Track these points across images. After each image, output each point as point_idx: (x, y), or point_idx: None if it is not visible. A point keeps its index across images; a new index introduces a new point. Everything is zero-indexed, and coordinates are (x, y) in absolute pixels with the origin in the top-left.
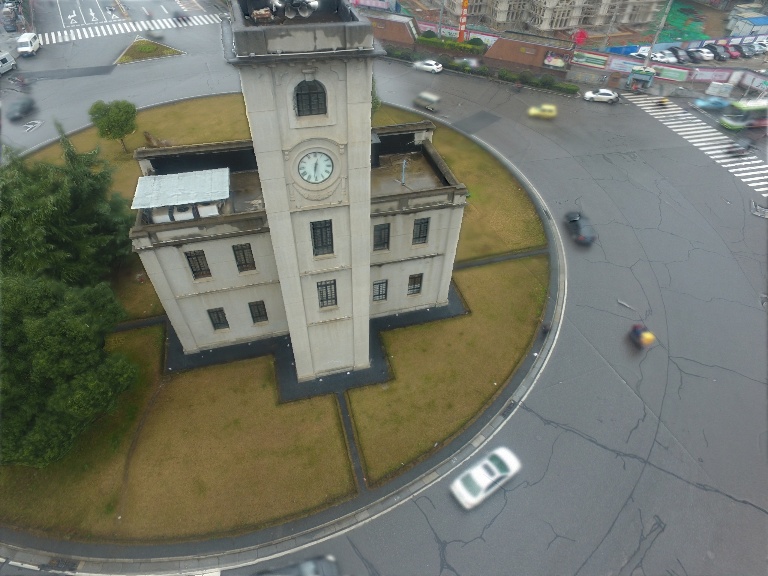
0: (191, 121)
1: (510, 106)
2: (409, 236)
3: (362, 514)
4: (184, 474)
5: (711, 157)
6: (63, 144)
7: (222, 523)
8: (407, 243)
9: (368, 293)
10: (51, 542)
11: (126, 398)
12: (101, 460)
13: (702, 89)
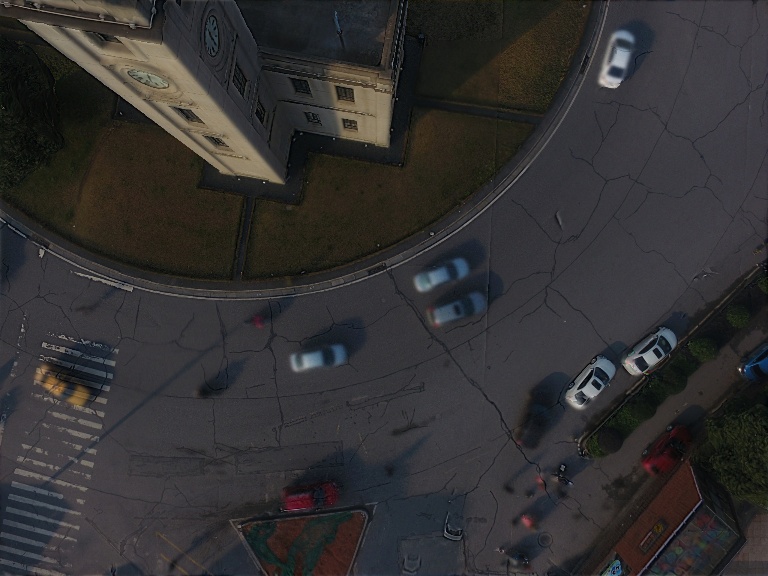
0: None
1: None
2: (332, 94)
3: (231, 294)
4: (118, 215)
5: None
6: None
7: (138, 260)
8: (331, 98)
9: (257, 154)
10: (31, 224)
11: (82, 130)
12: (63, 178)
13: None
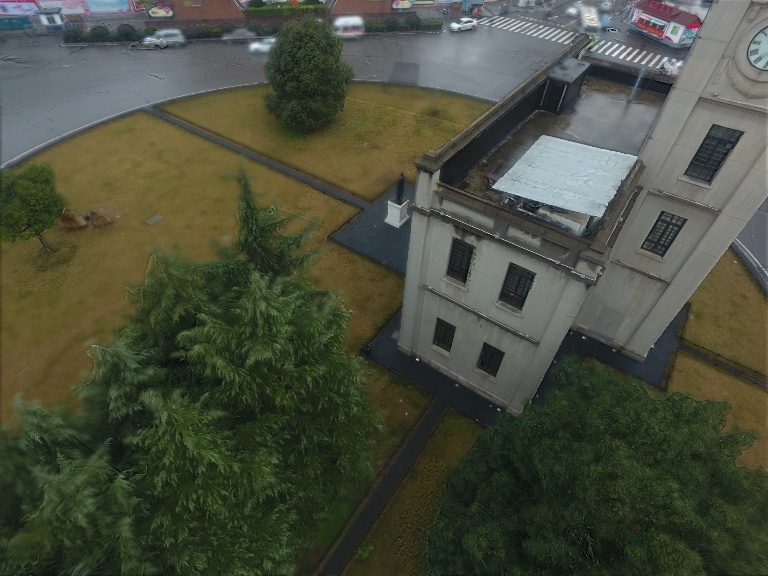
0: (89, 176)
1: (410, 52)
2: None
3: None
4: None
5: None
6: (248, 210)
7: None
8: None
9: None
10: None
11: None
12: None
13: (514, 4)
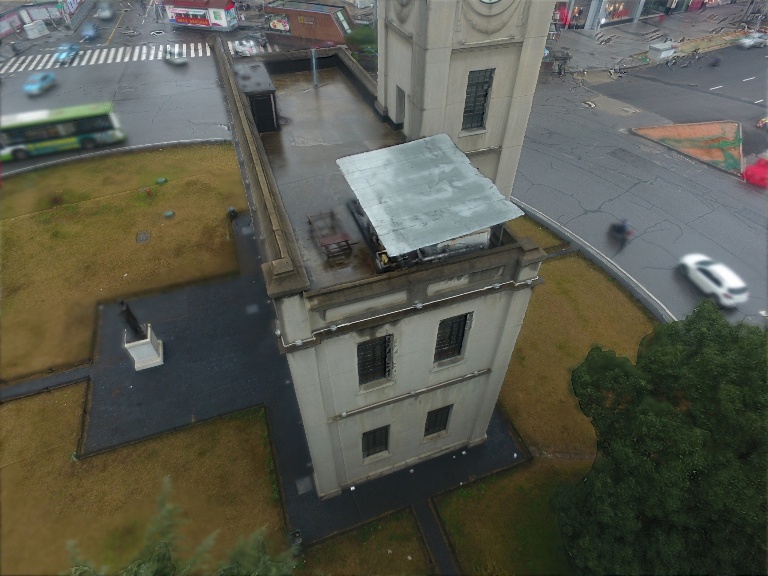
0: None
1: None
2: None
3: None
4: None
5: (151, 59)
6: None
7: None
8: None
9: None
10: None
11: None
12: None
13: None
